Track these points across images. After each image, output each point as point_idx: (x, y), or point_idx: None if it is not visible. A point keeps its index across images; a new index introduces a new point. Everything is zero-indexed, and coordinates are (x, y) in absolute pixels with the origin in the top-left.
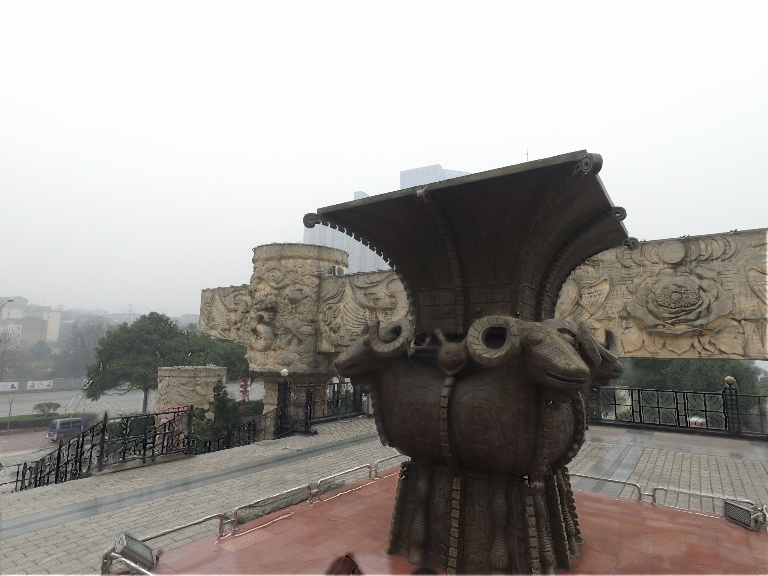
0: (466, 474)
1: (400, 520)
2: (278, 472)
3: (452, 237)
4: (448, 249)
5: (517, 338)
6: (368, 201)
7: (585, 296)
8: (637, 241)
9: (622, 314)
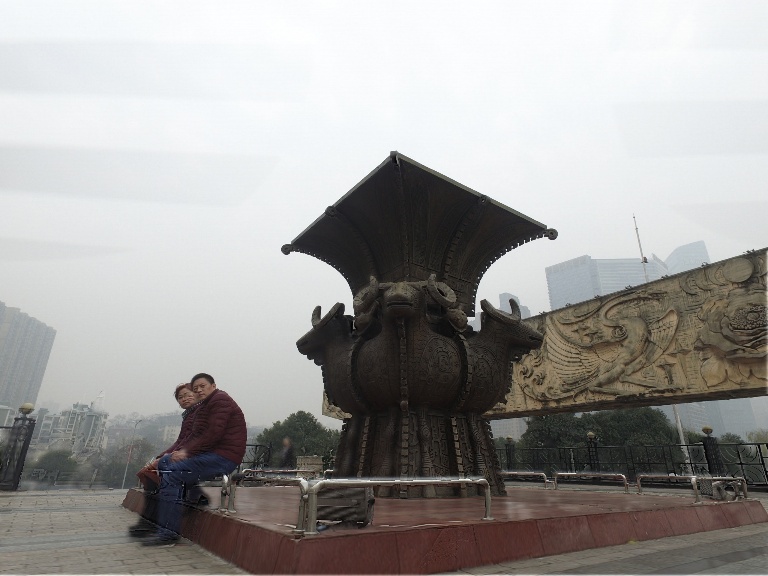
0: (377, 415)
1: (340, 464)
2: None
3: (364, 239)
4: (363, 248)
5: (374, 288)
6: (311, 226)
7: (654, 331)
8: (555, 231)
9: (696, 345)
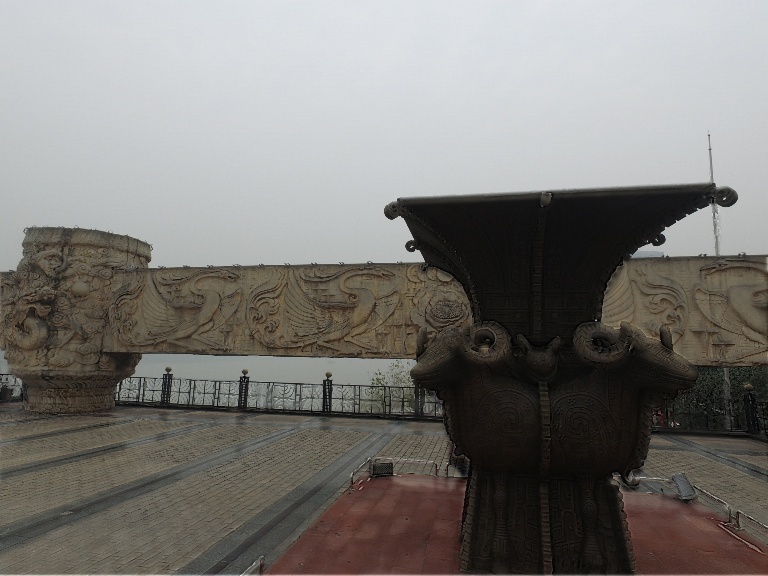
0: None
1: None
2: None
3: None
4: None
5: None
6: None
7: None
8: None
9: None
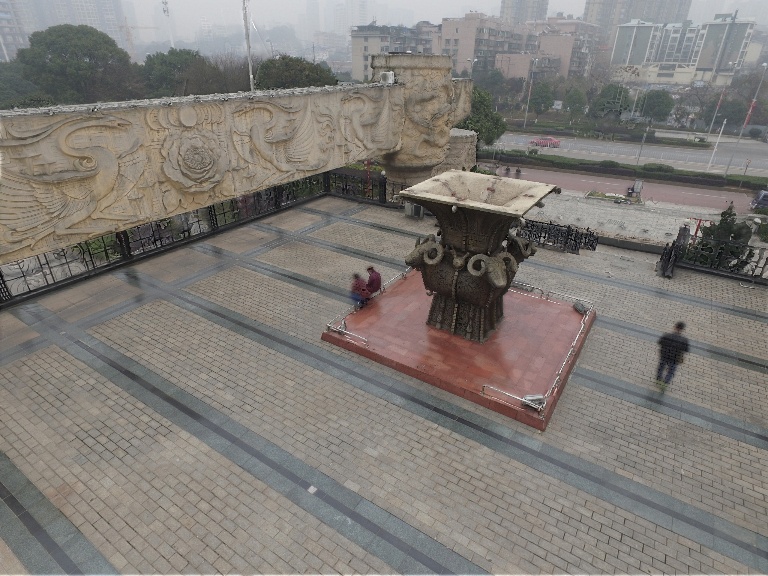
0: None
1: None
2: (555, 277)
3: None
4: None
5: None
6: None
7: None
8: (522, 222)
9: None
